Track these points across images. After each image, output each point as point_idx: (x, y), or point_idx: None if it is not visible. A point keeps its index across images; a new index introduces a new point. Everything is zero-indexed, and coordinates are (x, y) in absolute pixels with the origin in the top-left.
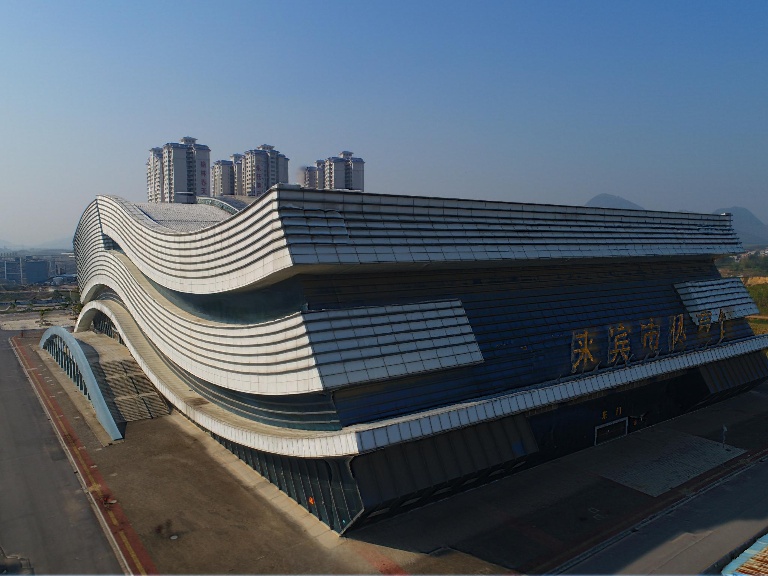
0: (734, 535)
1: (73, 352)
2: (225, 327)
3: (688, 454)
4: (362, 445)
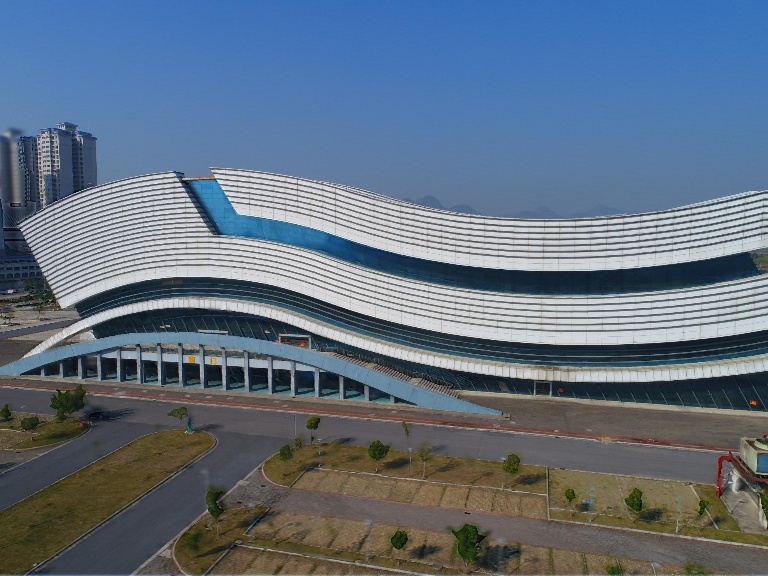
0: None
1: (289, 352)
2: (634, 295)
3: None
4: None
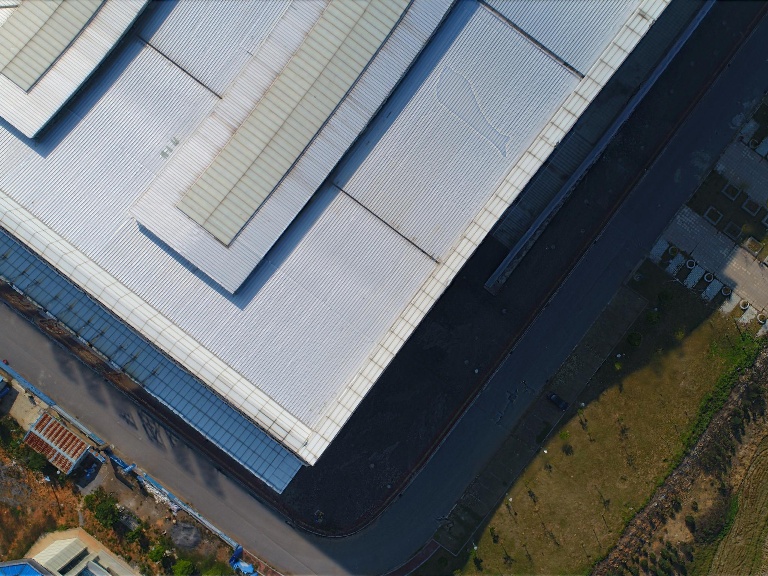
0: None
1: None
2: None
3: None
4: None
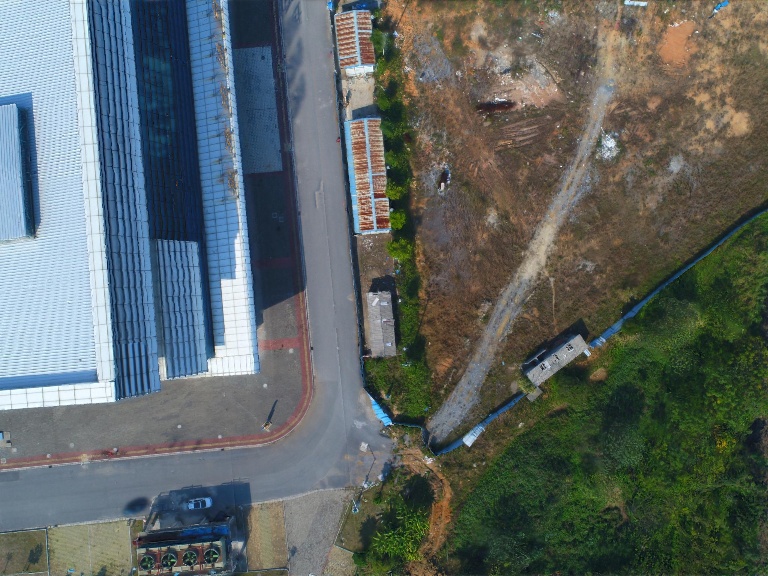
0: (330, 175)
1: None
2: None
3: (253, 91)
4: (258, 370)
